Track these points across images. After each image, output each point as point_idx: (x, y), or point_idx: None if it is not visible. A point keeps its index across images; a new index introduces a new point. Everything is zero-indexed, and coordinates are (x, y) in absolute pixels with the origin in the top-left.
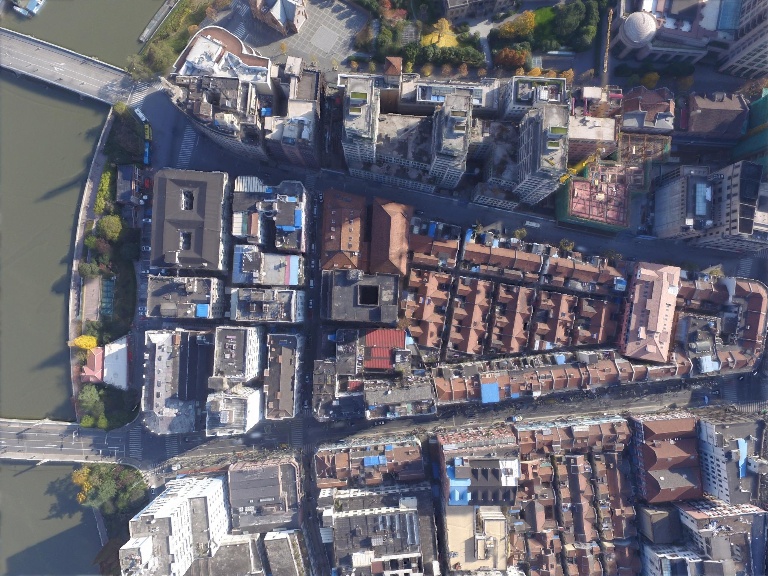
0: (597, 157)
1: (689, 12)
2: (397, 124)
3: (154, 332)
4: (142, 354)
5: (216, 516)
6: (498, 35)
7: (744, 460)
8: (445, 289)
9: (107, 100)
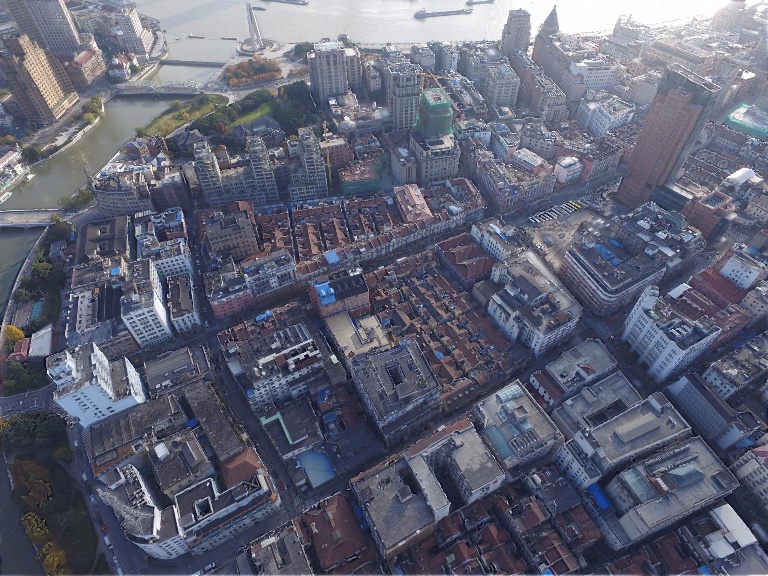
0: (324, 125)
1: None
2: (231, 172)
3: (77, 293)
4: (64, 337)
5: (134, 382)
6: None
7: (500, 232)
8: None
9: (45, 223)
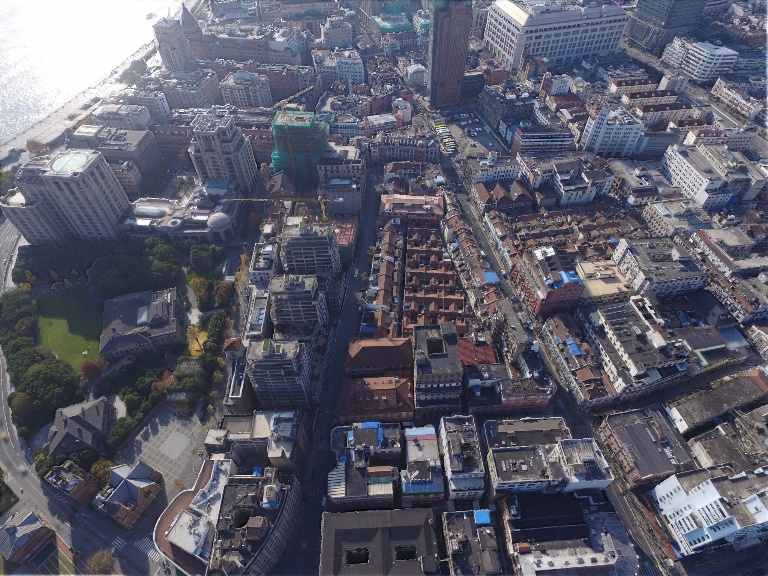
0: None
1: (214, 199)
2: None
3: None
4: None
5: None
6: (204, 301)
7: None
8: (415, 321)
9: None
